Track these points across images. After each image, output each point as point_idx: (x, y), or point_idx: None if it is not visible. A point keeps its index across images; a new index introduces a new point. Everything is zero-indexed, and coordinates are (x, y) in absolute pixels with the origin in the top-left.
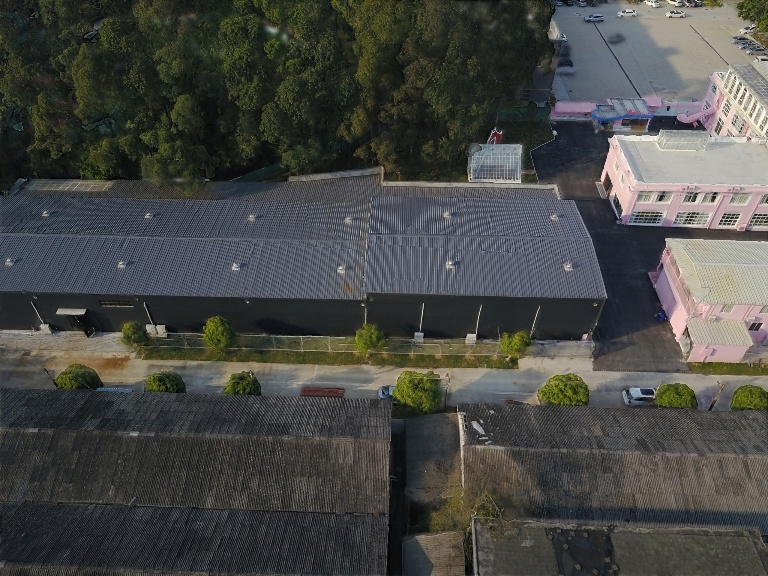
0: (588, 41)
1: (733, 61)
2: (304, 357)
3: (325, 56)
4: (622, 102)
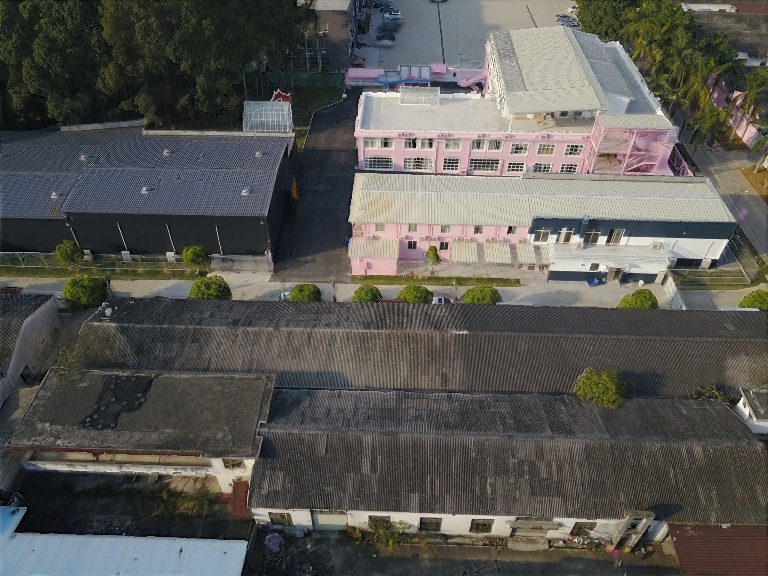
0: (423, 19)
1: None
2: (24, 272)
3: (73, 16)
4: (409, 68)
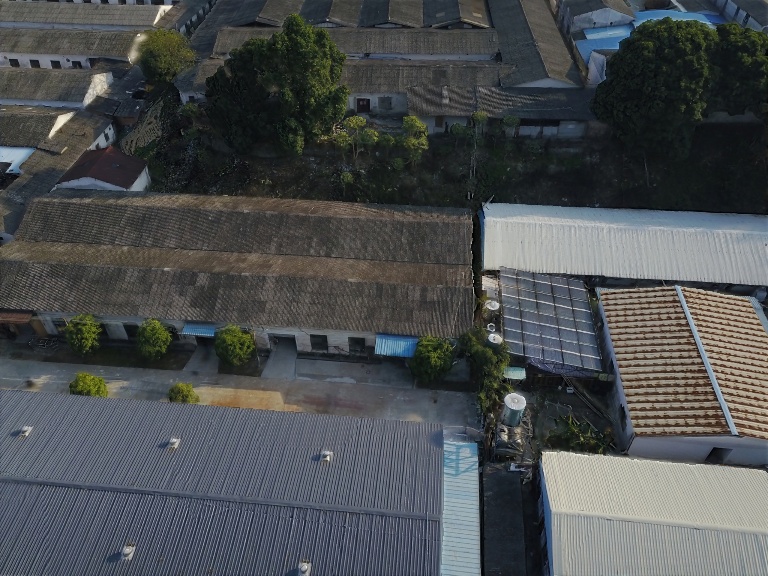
0: None
1: None
2: None
3: None
4: None
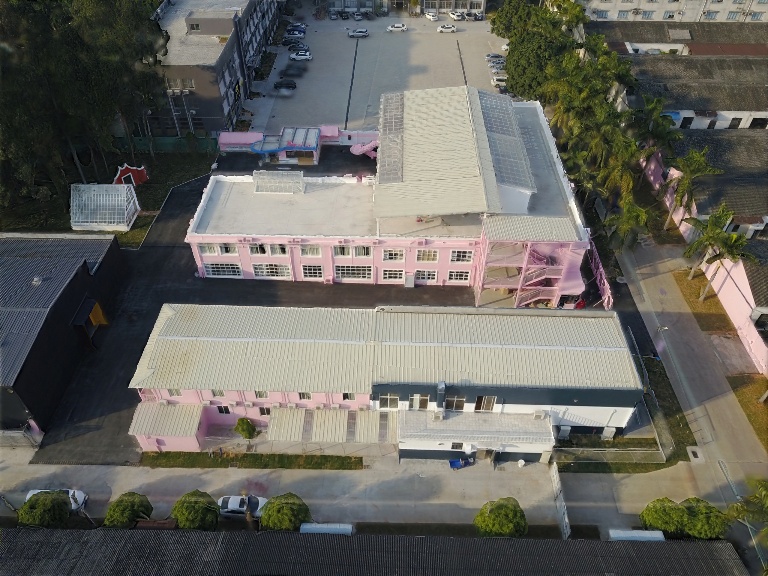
0: (336, 59)
1: (474, 81)
2: None
3: None
4: (294, 132)
